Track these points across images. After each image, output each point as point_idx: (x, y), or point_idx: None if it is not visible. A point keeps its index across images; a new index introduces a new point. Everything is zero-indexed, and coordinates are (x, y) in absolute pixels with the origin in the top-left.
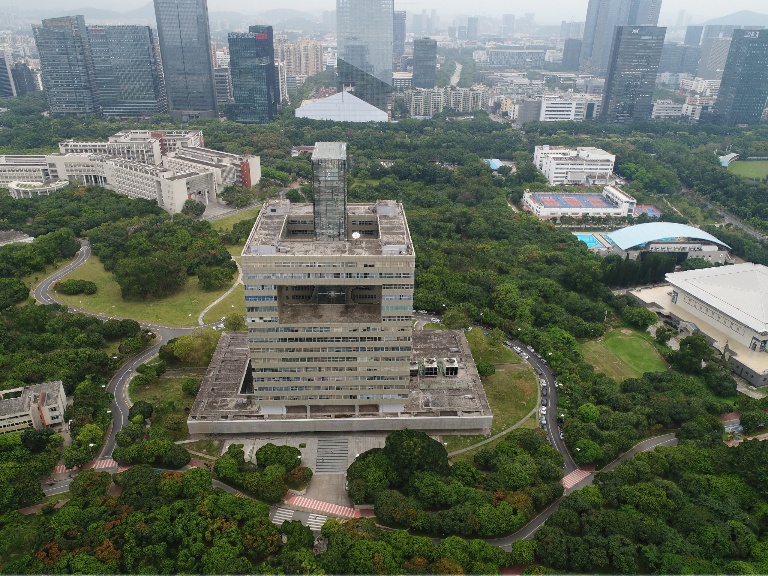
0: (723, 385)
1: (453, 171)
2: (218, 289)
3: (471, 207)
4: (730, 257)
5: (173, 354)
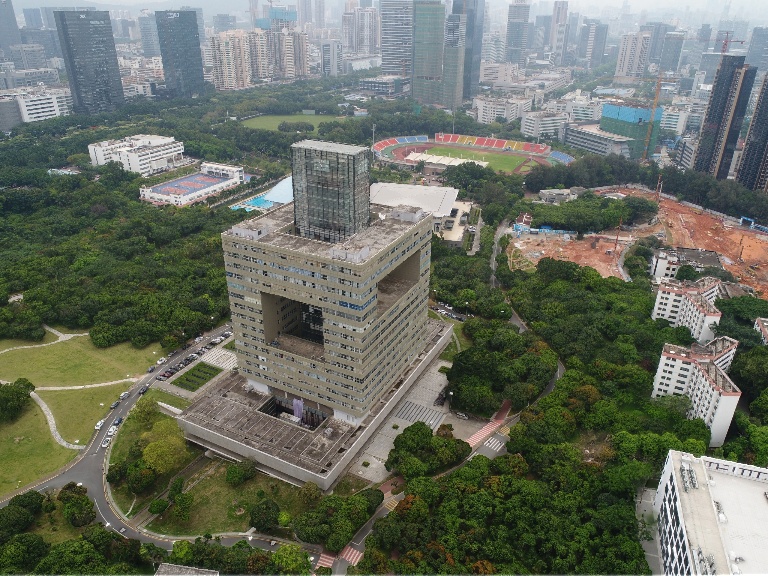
0: (464, 253)
1: (48, 190)
2: (21, 411)
3: (116, 218)
4: None
5: (155, 474)
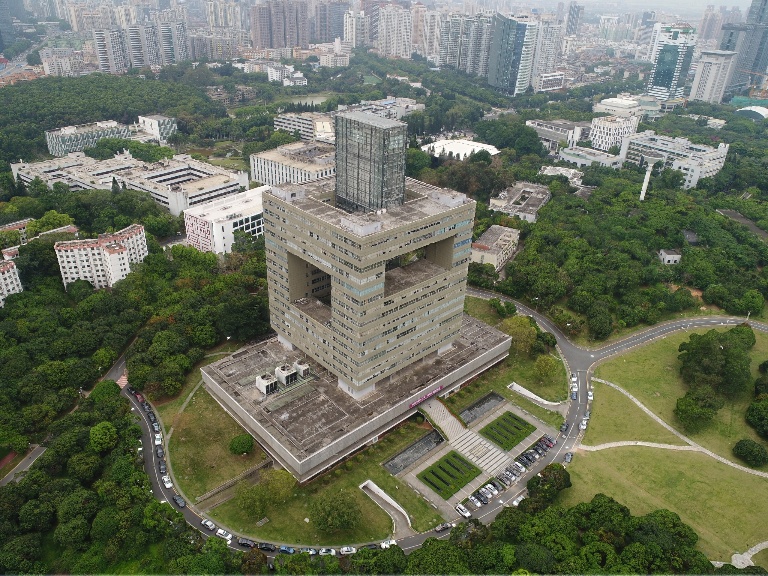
0: None
1: None
2: None
3: None
4: None
5: None
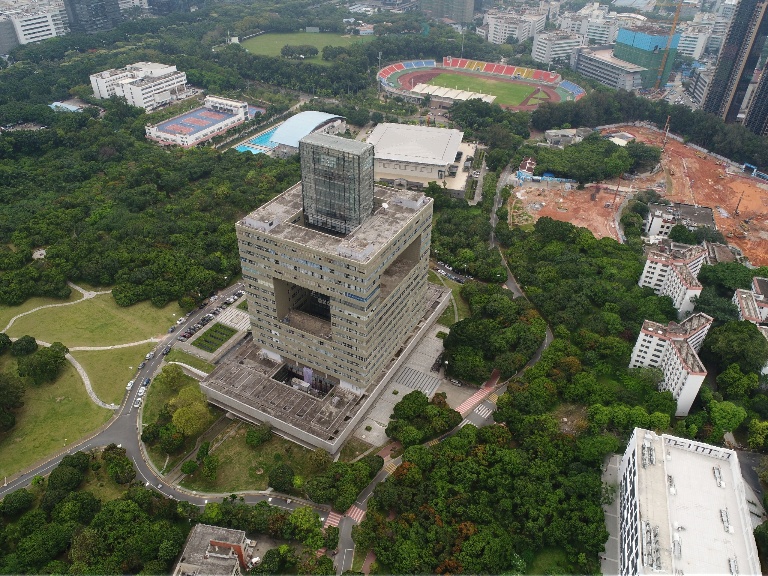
0: (466, 205)
1: (55, 131)
2: (58, 372)
3: (125, 162)
4: (345, 125)
5: (184, 436)
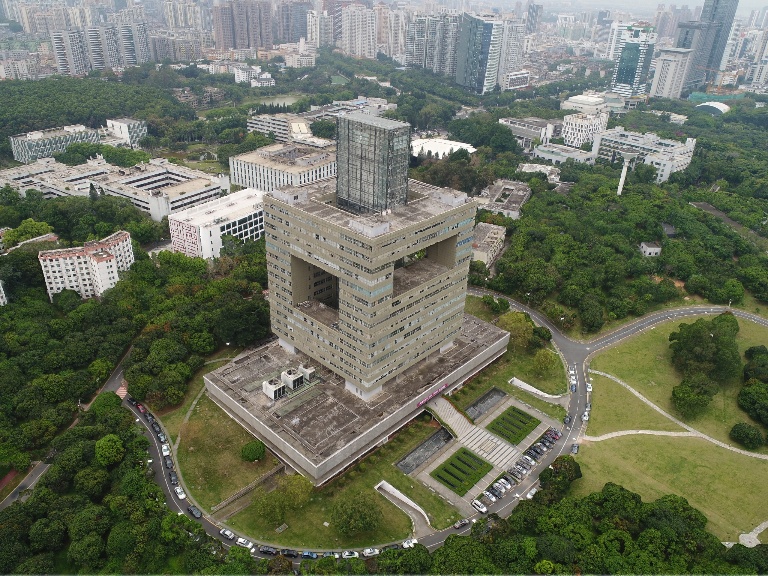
0: None
1: None
2: None
3: None
4: None
5: None
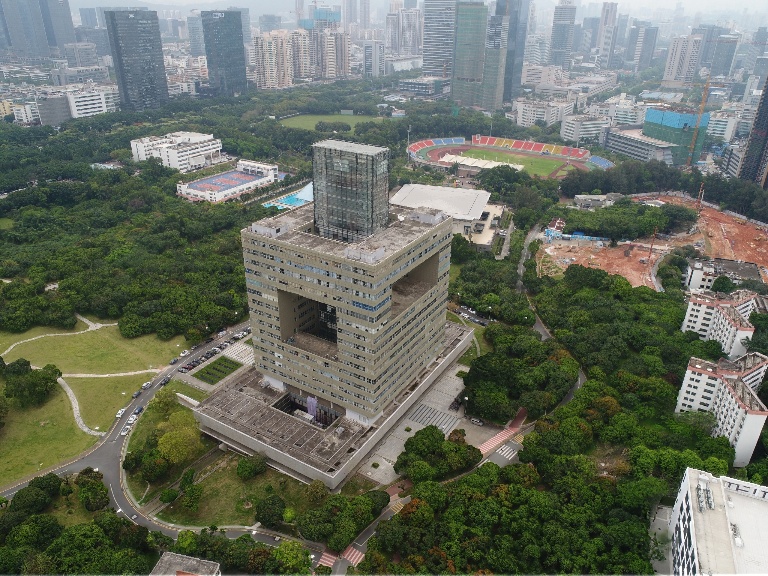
0: (492, 257)
1: (90, 184)
2: (48, 396)
3: (152, 213)
4: None
5: (169, 464)
